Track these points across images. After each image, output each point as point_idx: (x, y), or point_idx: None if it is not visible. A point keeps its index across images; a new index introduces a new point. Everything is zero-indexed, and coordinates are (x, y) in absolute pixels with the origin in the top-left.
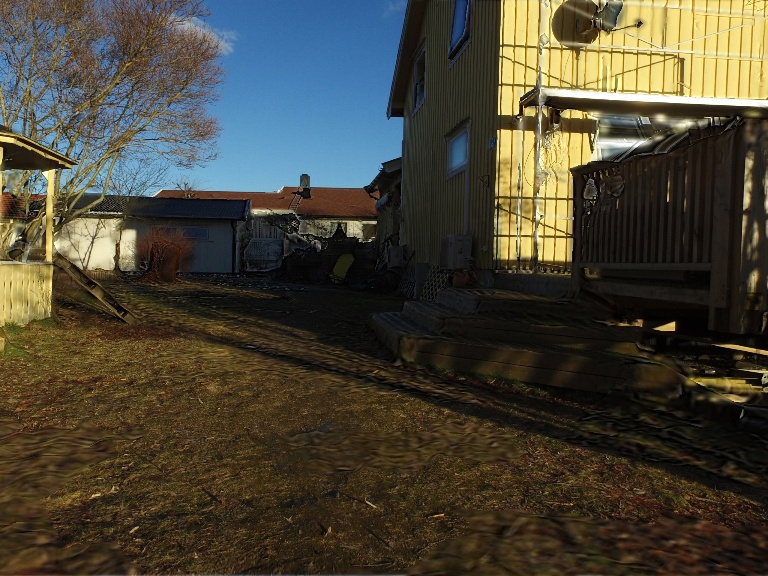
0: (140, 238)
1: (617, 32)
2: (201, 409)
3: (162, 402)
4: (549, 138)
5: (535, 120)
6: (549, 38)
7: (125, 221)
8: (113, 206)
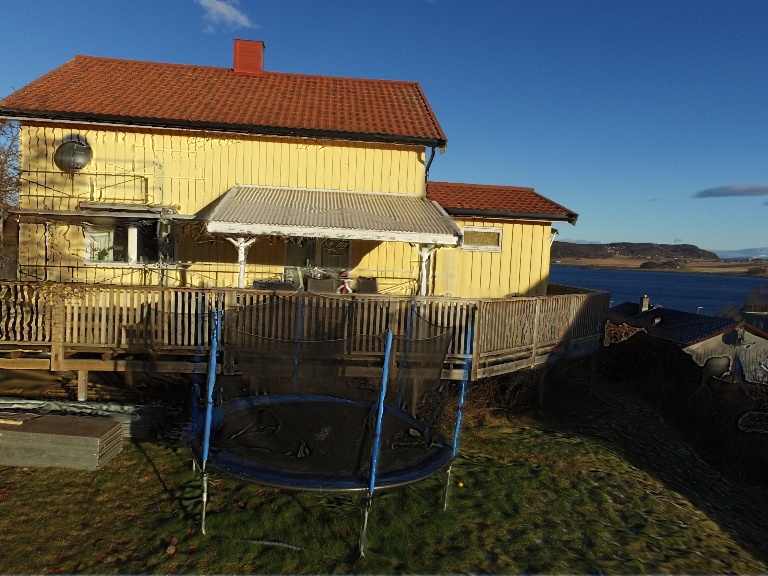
0: None
1: (100, 162)
2: None
3: None
4: None
5: None
6: (53, 166)
7: None
8: None
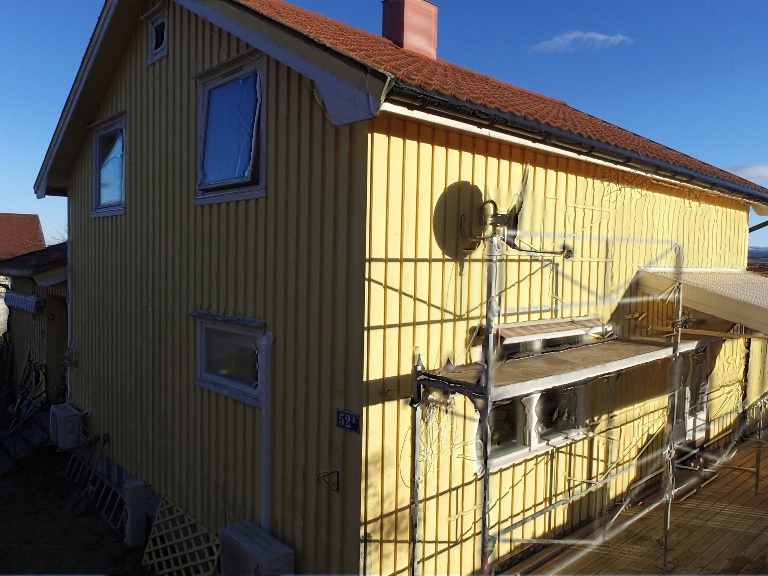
0: None
1: None
2: None
3: None
4: (434, 408)
5: (412, 379)
6: (429, 244)
7: None
8: None
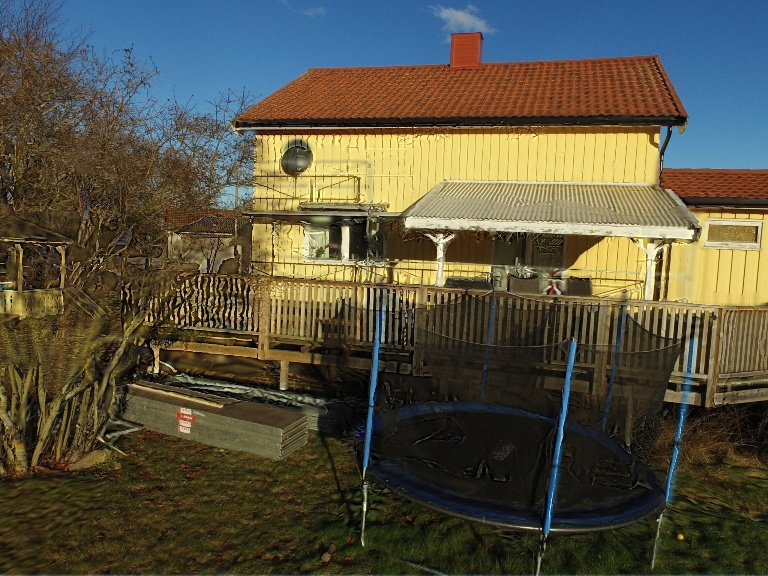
0: (245, 251)
1: (319, 164)
2: (3, 355)
3: (0, 352)
4: None
5: None
6: (280, 171)
7: (234, 240)
8: (232, 228)
